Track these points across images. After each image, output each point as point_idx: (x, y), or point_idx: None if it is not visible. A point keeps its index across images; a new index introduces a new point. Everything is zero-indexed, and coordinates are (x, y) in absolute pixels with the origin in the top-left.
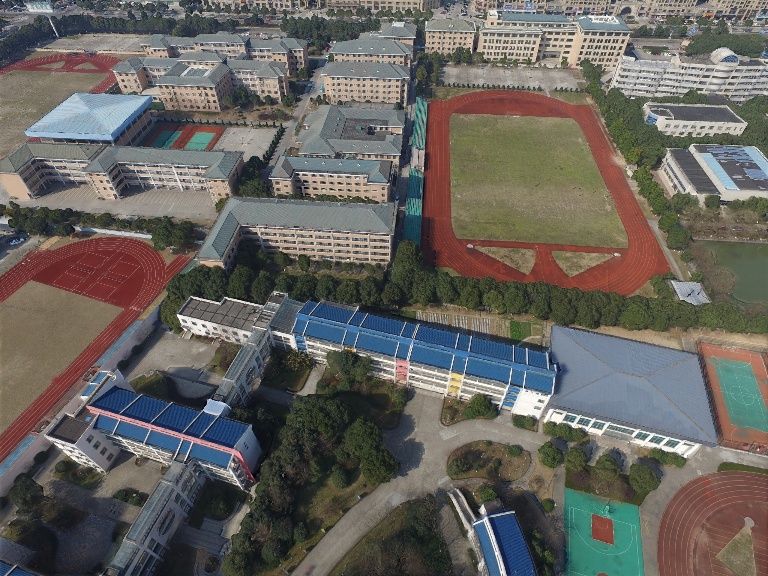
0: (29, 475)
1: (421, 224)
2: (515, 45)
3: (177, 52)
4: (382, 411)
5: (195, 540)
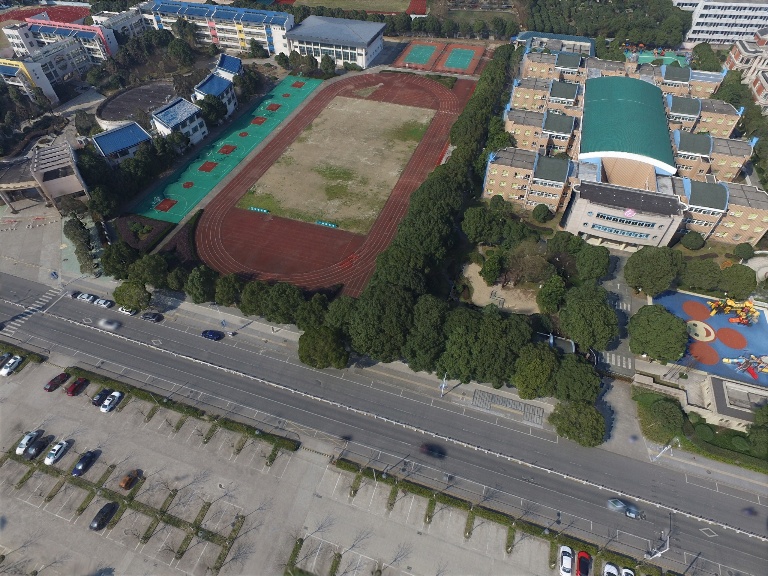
0: None
1: (272, 3)
2: None
3: None
4: (201, 55)
5: (79, 84)
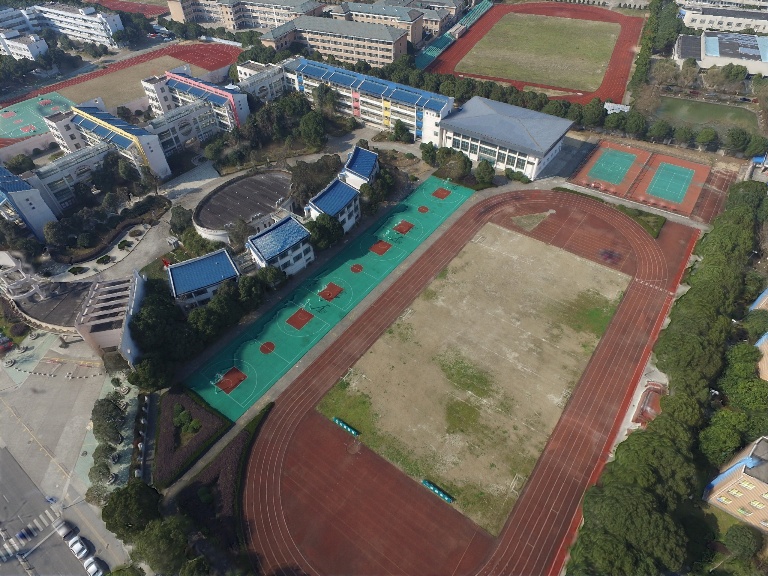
0: None
1: (432, 61)
2: None
3: None
4: (337, 129)
5: None
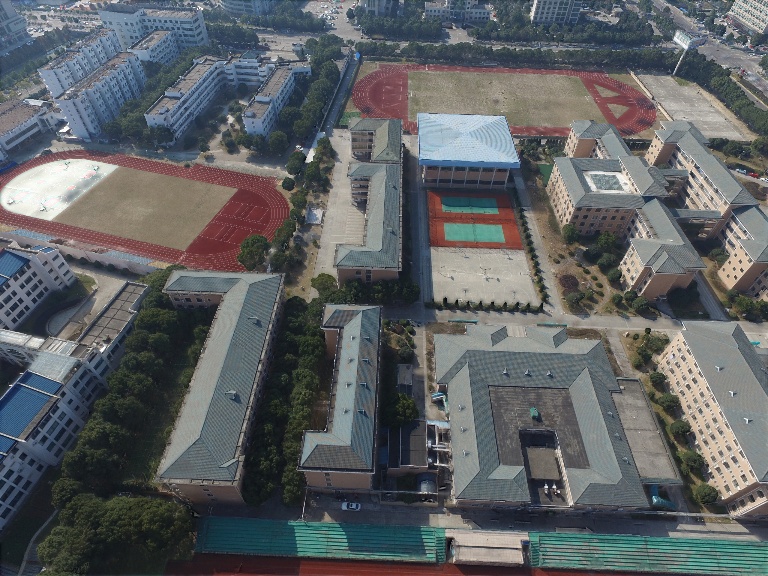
0: None
1: (277, 555)
2: None
3: (678, 155)
4: None
5: None
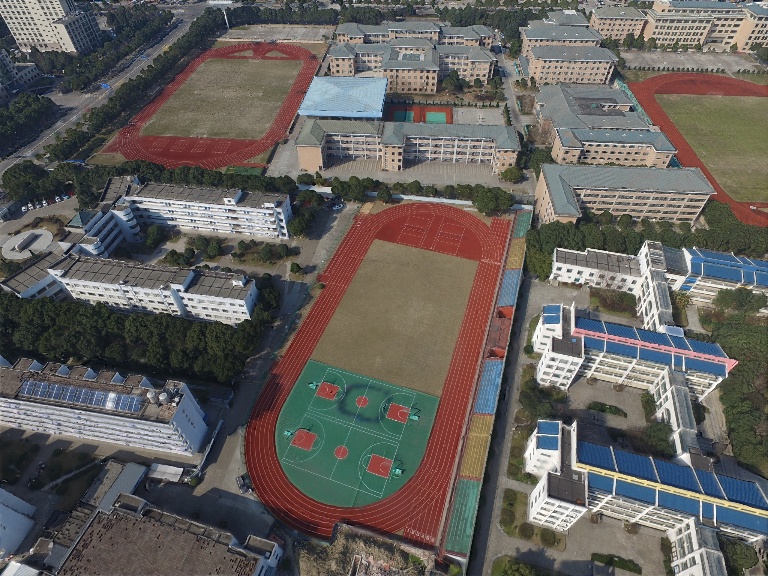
0: (503, 392)
1: None
2: (685, 31)
3: (368, 40)
4: None
5: None
